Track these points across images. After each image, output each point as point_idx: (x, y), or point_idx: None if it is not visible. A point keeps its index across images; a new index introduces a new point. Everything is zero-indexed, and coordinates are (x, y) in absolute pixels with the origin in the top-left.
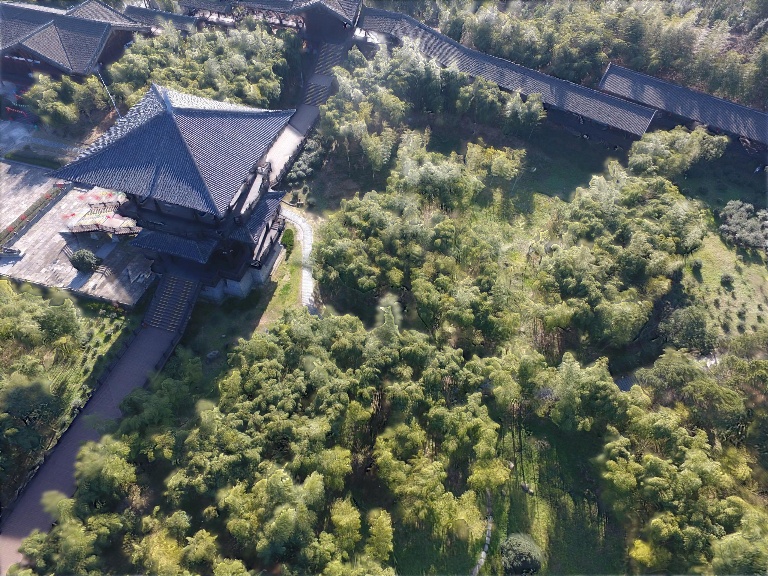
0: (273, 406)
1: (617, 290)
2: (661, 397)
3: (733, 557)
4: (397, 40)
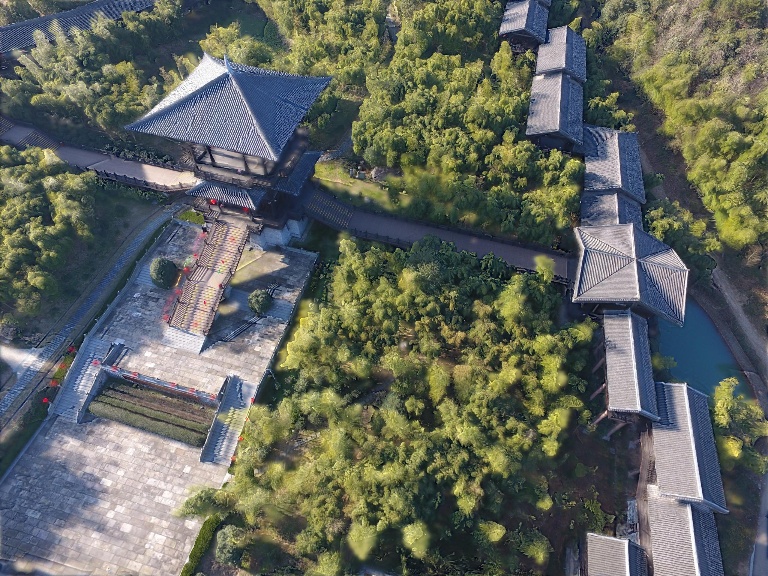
0: (427, 127)
1: (361, 5)
2: (419, 9)
3: (484, 3)
4: (0, 57)
